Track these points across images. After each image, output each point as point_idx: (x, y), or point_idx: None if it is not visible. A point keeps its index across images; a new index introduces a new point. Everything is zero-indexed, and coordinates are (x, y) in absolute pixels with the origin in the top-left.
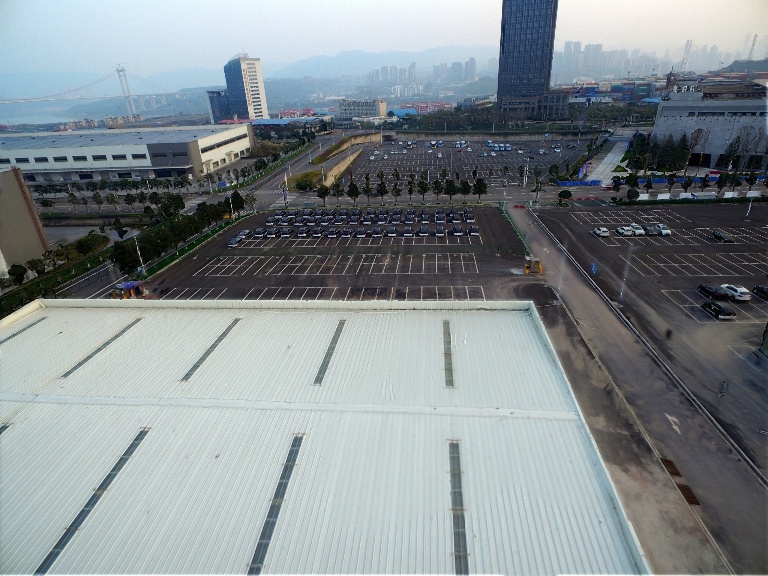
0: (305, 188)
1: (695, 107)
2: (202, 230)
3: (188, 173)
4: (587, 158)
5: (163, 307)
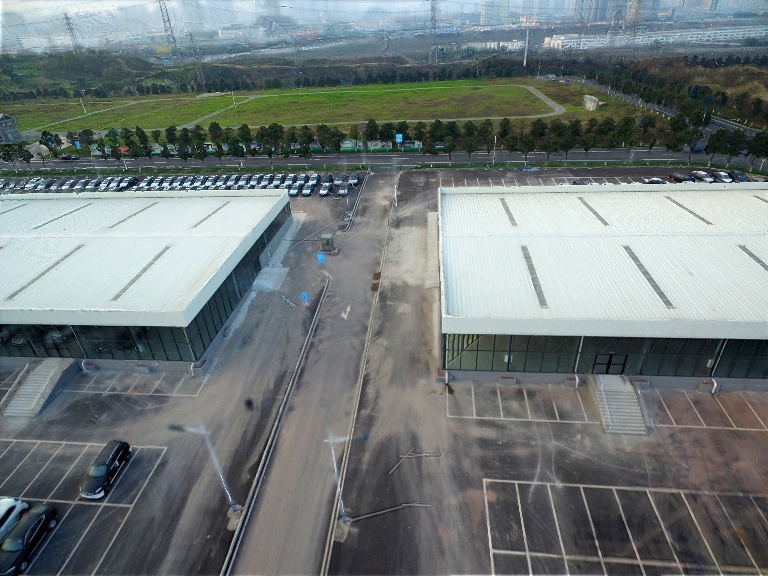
0: None
1: None
2: None
3: None
4: None
5: None
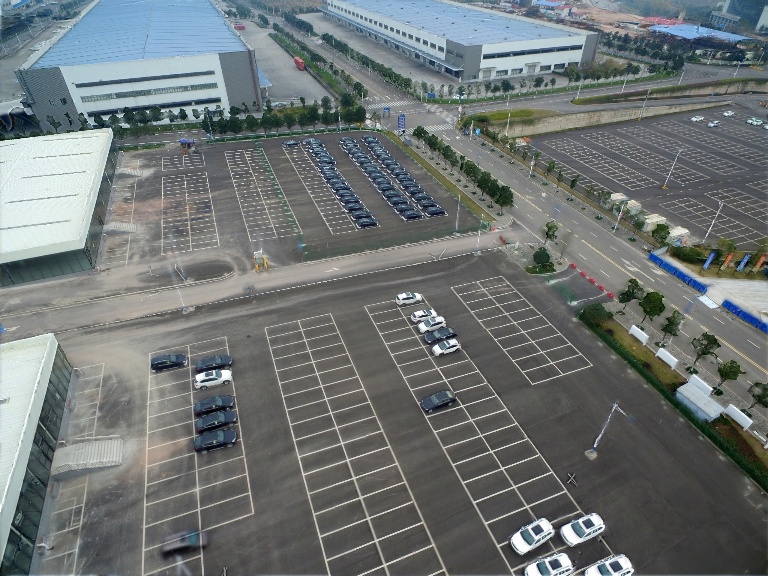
0: (465, 125)
1: None
2: (303, 127)
3: (460, 75)
4: None
5: None
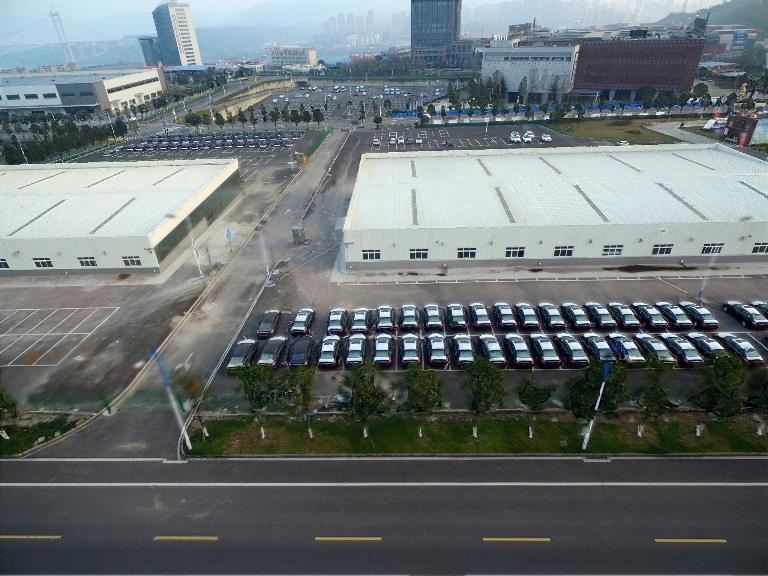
0: None
1: (508, 53)
2: (86, 146)
3: None
4: (439, 98)
5: (22, 169)
